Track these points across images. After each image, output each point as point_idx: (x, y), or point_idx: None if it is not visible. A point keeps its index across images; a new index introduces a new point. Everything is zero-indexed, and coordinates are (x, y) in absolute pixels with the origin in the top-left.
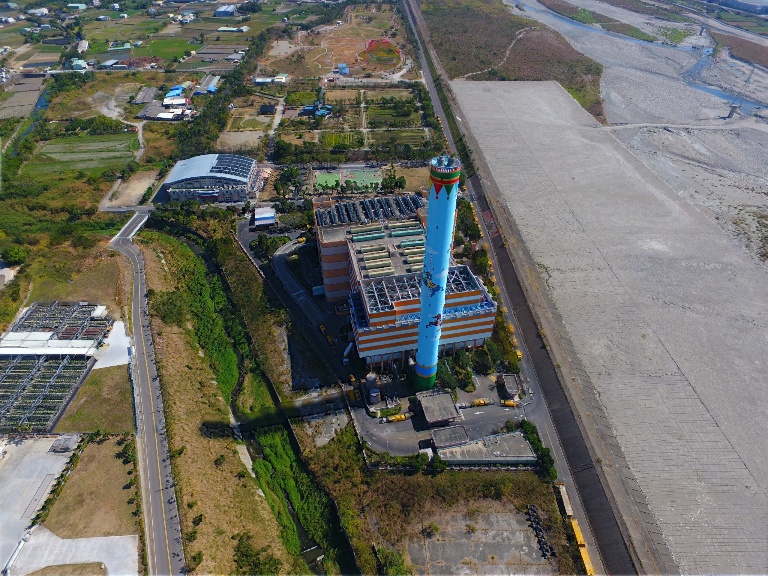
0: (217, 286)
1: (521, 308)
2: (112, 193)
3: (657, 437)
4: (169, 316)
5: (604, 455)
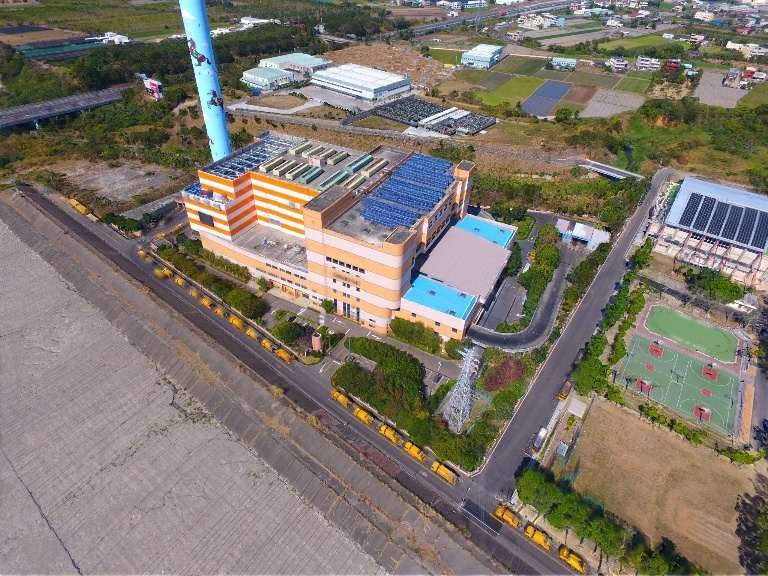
0: (473, 189)
1: (189, 312)
2: (711, 177)
3: (6, 284)
4: (436, 151)
5: (63, 243)
